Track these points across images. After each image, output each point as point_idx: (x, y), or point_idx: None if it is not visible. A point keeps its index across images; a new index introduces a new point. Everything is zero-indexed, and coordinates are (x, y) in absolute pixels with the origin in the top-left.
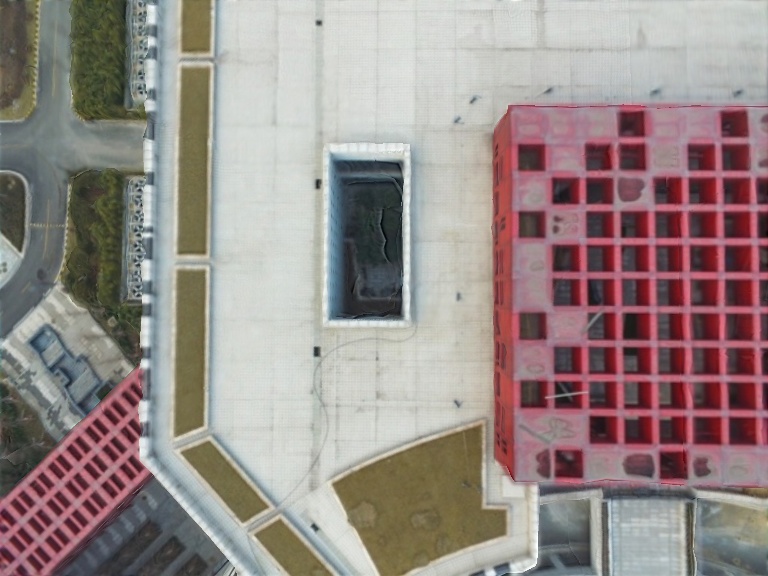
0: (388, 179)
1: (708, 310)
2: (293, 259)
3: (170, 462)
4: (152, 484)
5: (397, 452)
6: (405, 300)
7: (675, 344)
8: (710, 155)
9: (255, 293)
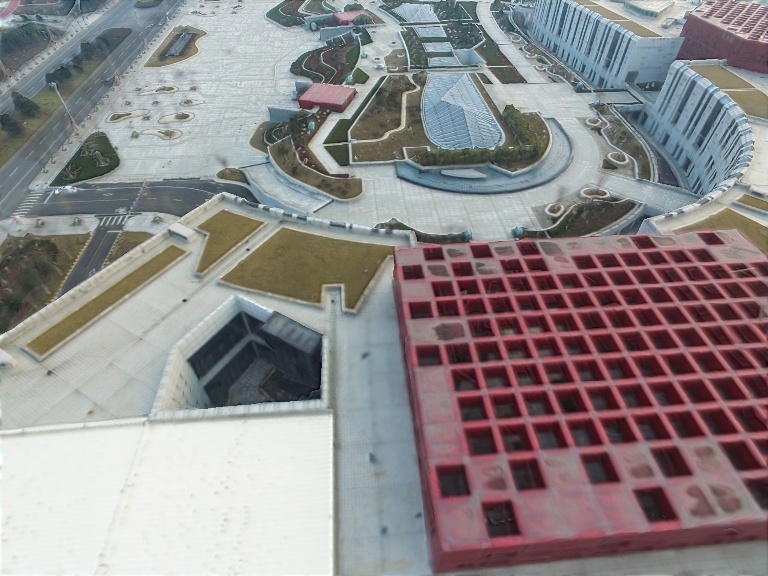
0: None
1: (676, 326)
2: None
3: None
4: None
5: None
6: None
7: (688, 303)
8: (765, 455)
9: None
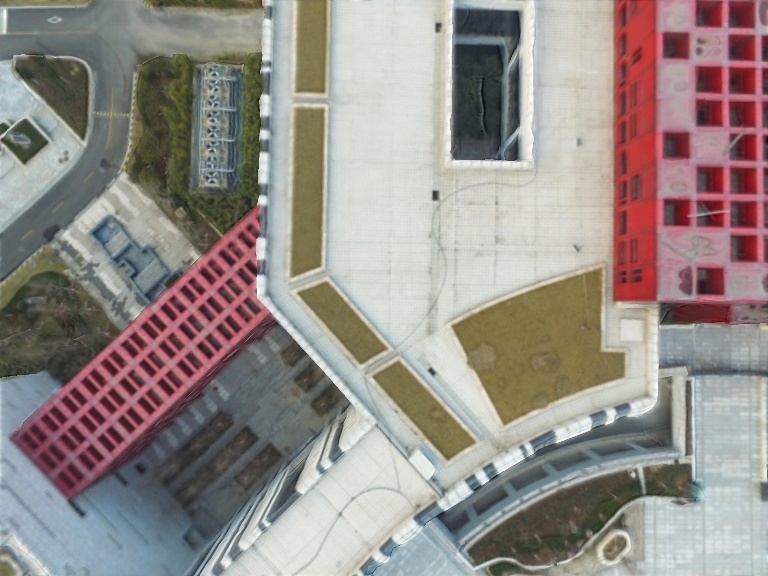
0: (494, 41)
1: None
2: (412, 102)
3: (285, 304)
4: (225, 372)
5: (517, 294)
6: (528, 142)
7: None
8: None
9: (373, 135)
